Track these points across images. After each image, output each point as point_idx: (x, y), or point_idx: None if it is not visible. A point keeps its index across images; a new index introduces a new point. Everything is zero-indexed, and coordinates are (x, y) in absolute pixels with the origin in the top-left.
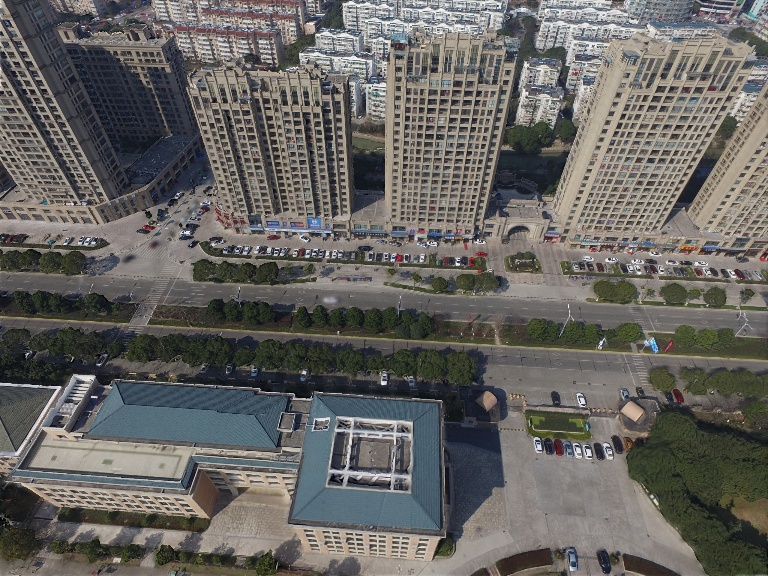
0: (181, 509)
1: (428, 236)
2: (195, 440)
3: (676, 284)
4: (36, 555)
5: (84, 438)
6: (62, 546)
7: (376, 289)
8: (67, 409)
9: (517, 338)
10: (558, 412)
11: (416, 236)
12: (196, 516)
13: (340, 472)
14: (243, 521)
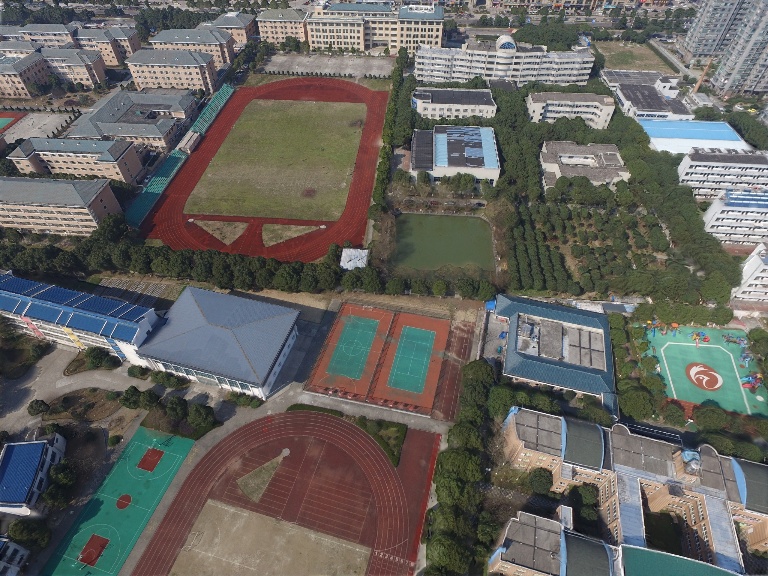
0: (356, 42)
1: (439, 2)
2: (364, 10)
3: (544, 7)
4: (308, 55)
5: (328, 11)
6: (319, 49)
7: None
8: (321, 4)
9: (476, 25)
10: (488, 35)
11: (433, 3)
12: (359, 50)
13: (412, 11)
14: (375, 52)
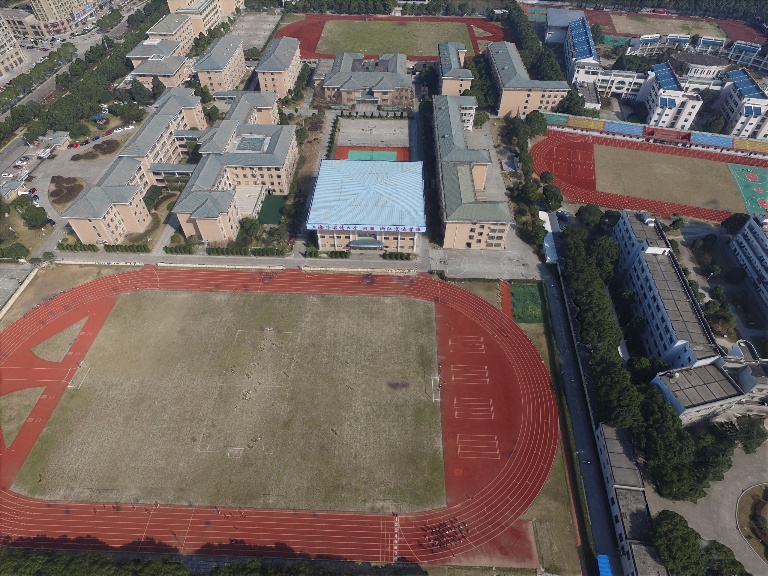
0: None
1: None
2: None
3: None
4: None
5: None
6: None
7: (139, 8)
8: None
9: None
10: None
11: None
12: None
13: None
14: None
